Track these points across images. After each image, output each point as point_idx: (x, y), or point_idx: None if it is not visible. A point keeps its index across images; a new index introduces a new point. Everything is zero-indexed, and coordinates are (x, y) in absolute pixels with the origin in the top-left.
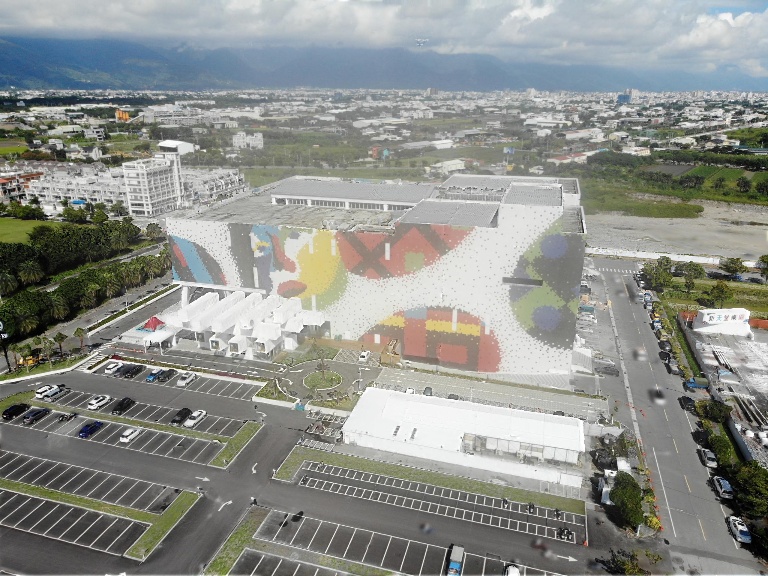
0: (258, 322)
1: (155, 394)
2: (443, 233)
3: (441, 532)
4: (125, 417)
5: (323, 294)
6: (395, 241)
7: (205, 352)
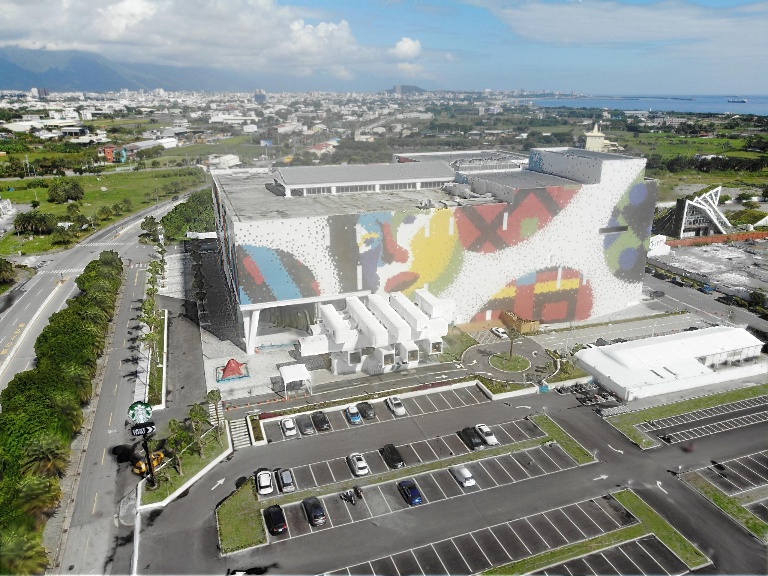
0: None
1: (391, 432)
2: (556, 195)
3: None
4: (418, 464)
5: (437, 280)
6: (513, 209)
7: (354, 376)
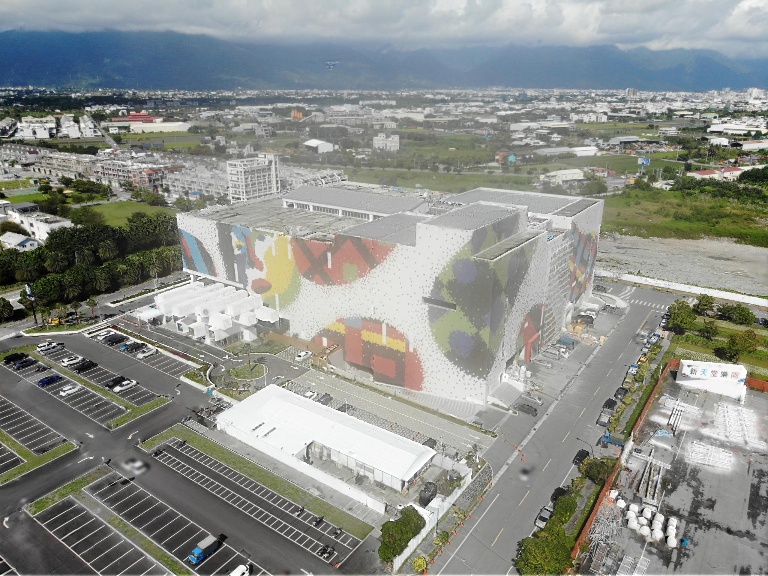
0: (215, 312)
1: (117, 361)
2: (372, 247)
3: (223, 522)
4: (79, 376)
5: (284, 294)
6: (335, 251)
7: (181, 333)
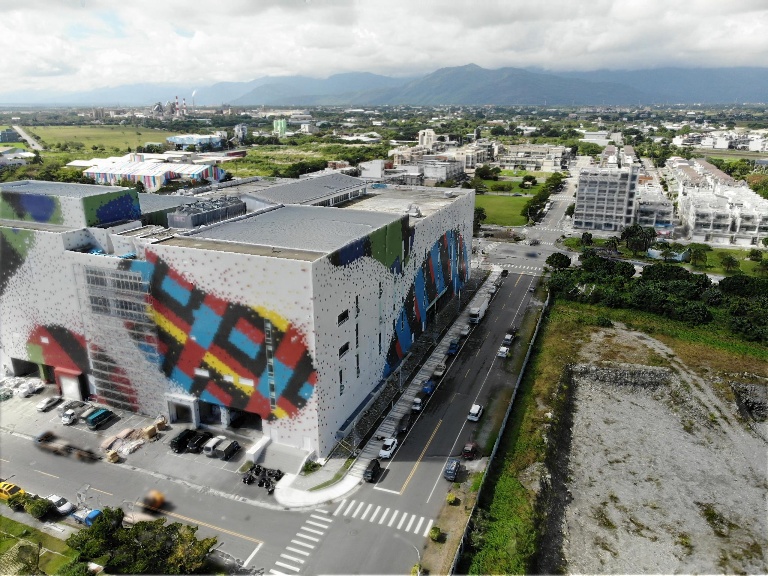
0: None
1: None
2: None
3: None
4: None
5: None
6: None
7: None
